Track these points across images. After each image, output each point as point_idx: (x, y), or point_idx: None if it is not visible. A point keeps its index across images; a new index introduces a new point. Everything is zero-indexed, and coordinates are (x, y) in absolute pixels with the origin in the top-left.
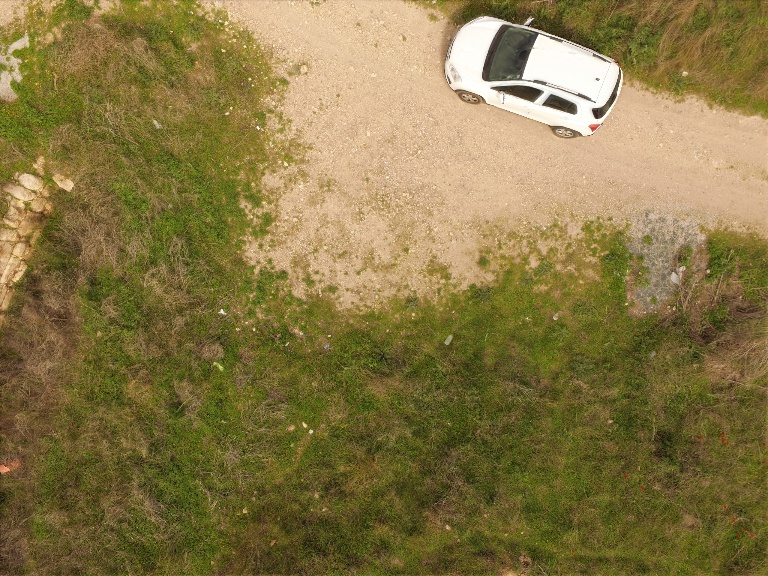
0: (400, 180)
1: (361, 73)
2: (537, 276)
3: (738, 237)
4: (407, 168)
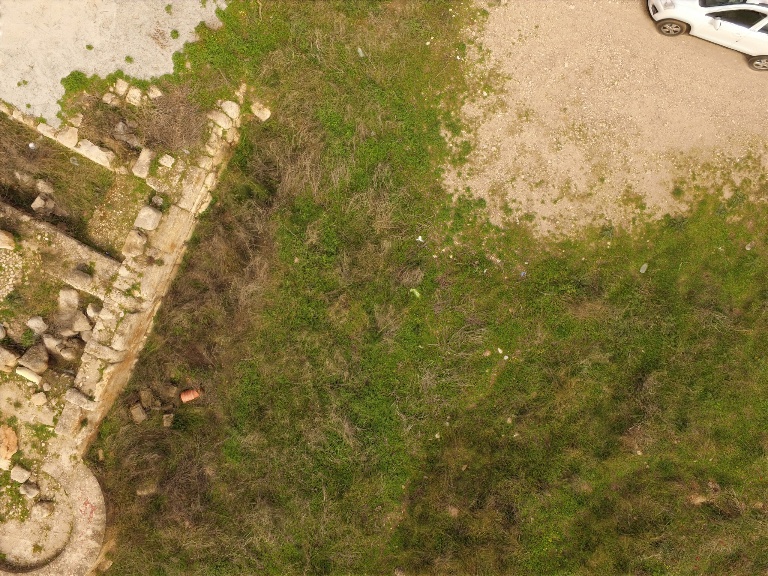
0: (597, 111)
1: (559, 5)
2: (730, 207)
3: None
4: (604, 99)
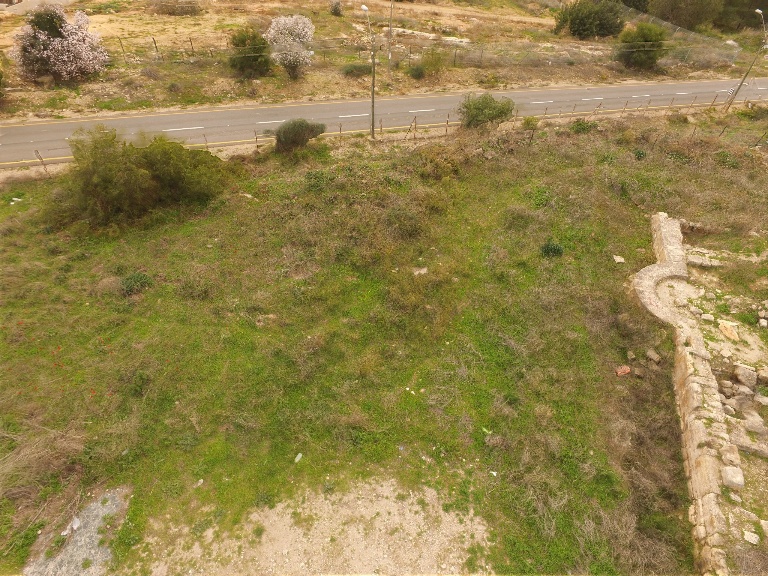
0: None
1: None
2: (209, 520)
3: None
4: None
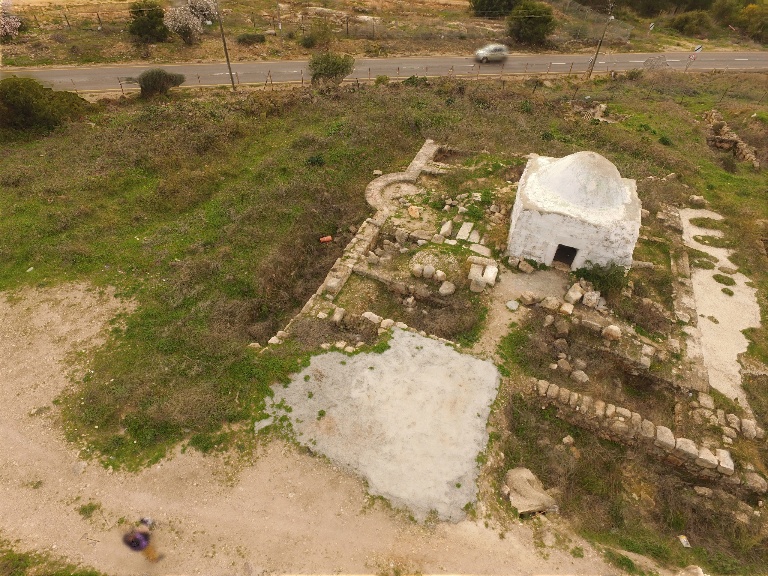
0: (6, 344)
1: None
2: None
3: None
4: None
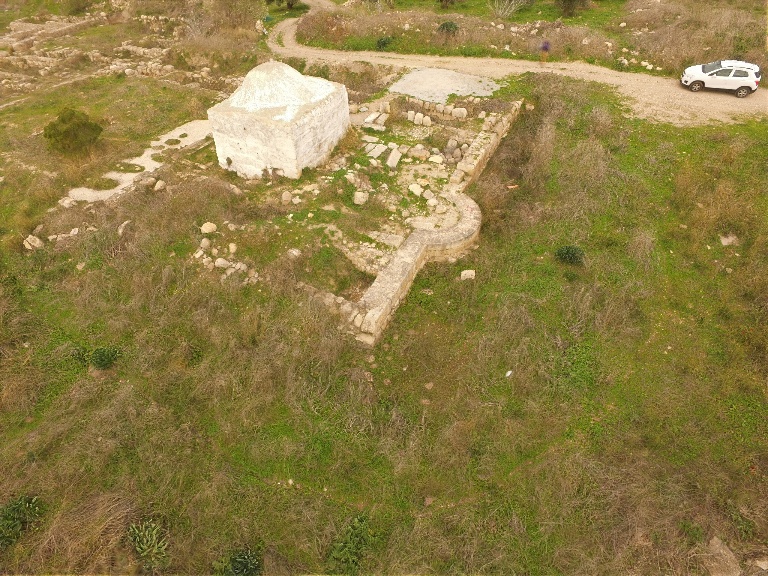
0: None
1: None
2: (763, 122)
3: None
4: None
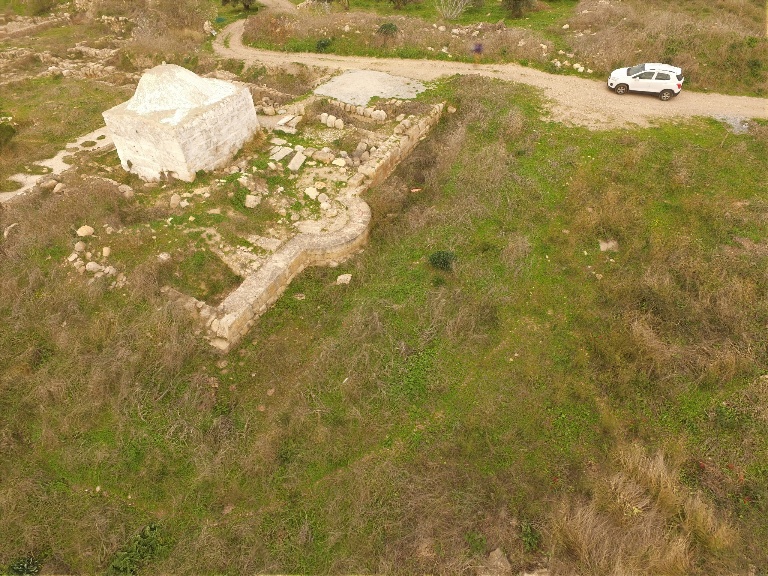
0: None
1: None
2: None
3: (765, 119)
4: None
